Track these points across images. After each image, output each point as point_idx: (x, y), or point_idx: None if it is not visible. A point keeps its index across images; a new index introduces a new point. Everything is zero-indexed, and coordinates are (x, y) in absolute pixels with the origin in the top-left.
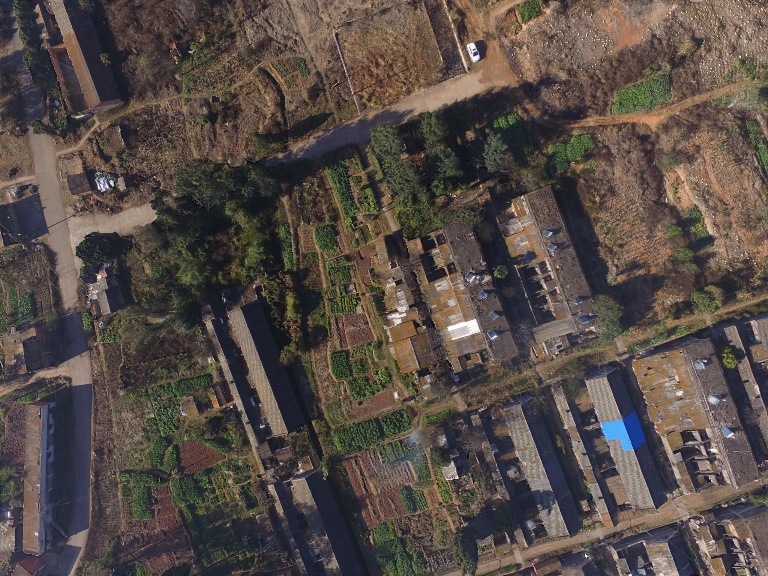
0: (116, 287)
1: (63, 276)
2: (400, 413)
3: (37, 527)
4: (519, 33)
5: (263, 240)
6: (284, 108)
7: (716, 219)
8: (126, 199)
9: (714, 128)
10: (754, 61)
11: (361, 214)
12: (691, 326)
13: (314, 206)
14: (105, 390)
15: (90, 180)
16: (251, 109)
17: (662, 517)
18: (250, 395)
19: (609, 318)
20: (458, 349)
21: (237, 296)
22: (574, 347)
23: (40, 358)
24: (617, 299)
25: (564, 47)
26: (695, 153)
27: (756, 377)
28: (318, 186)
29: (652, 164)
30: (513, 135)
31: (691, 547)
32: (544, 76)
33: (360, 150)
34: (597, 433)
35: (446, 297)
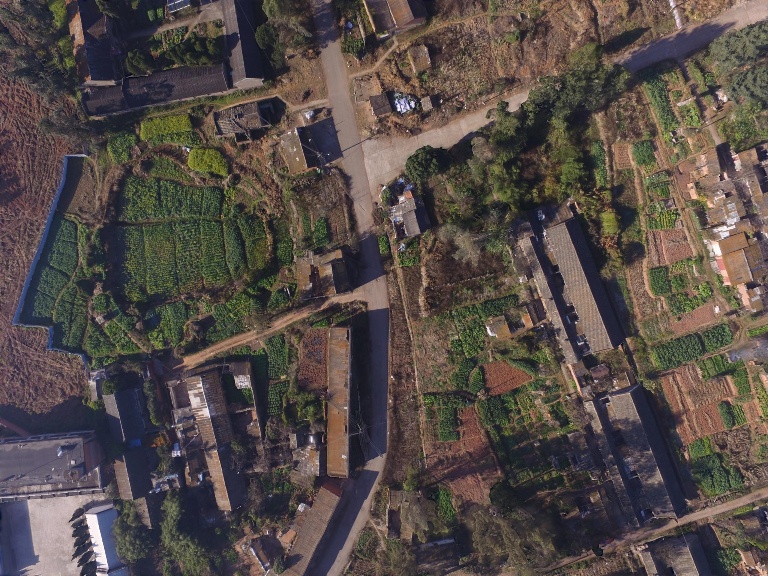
0: (423, 208)
1: (358, 200)
2: (722, 327)
3: (344, 450)
4: None
5: None
6: (597, 24)
7: None
8: (427, 120)
9: None
10: None
11: (682, 128)
12: None
13: (631, 122)
14: (402, 314)
15: (389, 101)
16: (561, 26)
17: None
18: (565, 313)
19: None
20: None
21: (552, 214)
22: None
23: (346, 280)
24: None
25: None
26: None
27: None
28: (636, 101)
29: None
30: None
31: None
32: None
33: (679, 64)
34: None
35: None
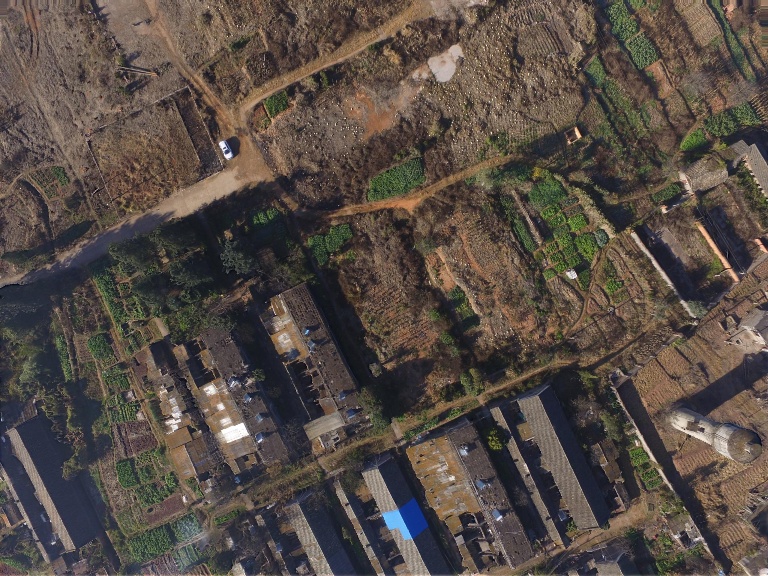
0: None
1: None
2: (189, 517)
3: None
4: (268, 128)
5: (39, 353)
6: (48, 218)
7: (479, 298)
8: None
9: (467, 208)
10: (506, 136)
11: (131, 321)
12: (464, 407)
13: (86, 316)
14: None
15: None
16: (16, 221)
17: None
18: (40, 511)
19: (372, 411)
20: (233, 452)
21: (17, 413)
22: (349, 439)
23: None
24: (376, 393)
25: (314, 138)
26: (451, 235)
27: (525, 455)
28: (87, 296)
29: (412, 248)
30: (274, 230)
31: None
32: (296, 169)
33: None
34: (384, 520)
35: (215, 401)
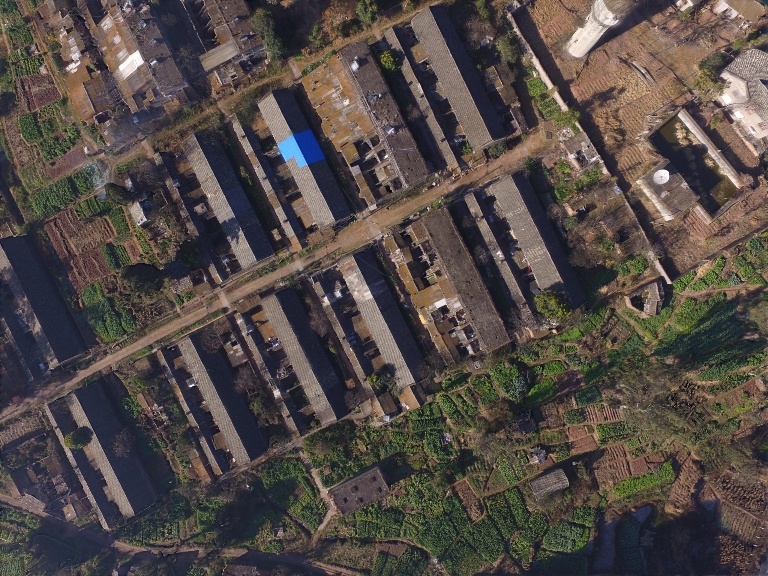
0: None
1: None
2: (91, 167)
3: None
4: None
5: None
6: None
7: None
8: None
9: None
10: None
11: None
12: None
13: None
14: None
15: None
16: None
17: (356, 239)
18: None
19: (264, 30)
20: (130, 87)
21: None
22: None
23: None
24: (268, 9)
25: None
26: None
27: (419, 77)
28: None
29: None
30: None
31: (385, 264)
32: None
33: None
34: None
35: (112, 35)
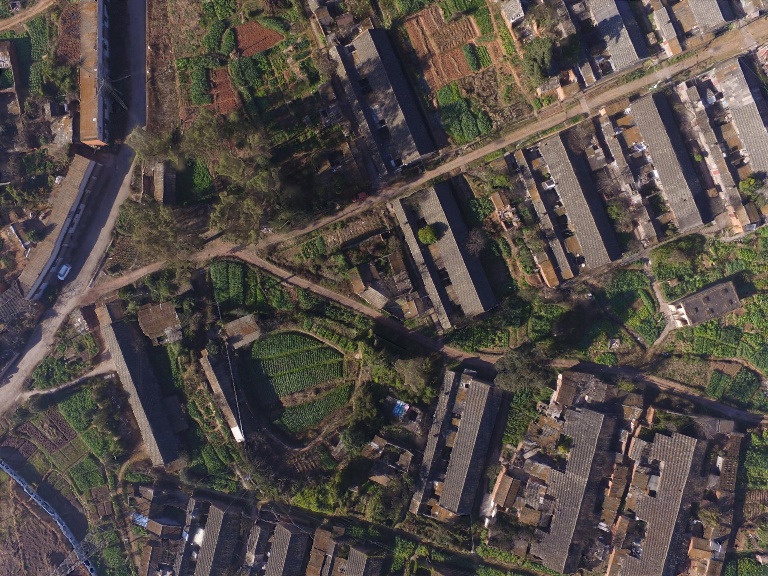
0: None
1: None
2: None
3: (95, 112)
4: None
5: None
6: None
7: None
8: None
9: None
10: None
11: None
12: None
13: None
14: None
15: None
16: None
17: (729, 49)
18: None
19: None
20: None
21: None
22: None
23: None
24: None
25: None
26: None
27: None
28: None
29: None
30: None
31: (760, 73)
32: None
33: None
34: None
35: None
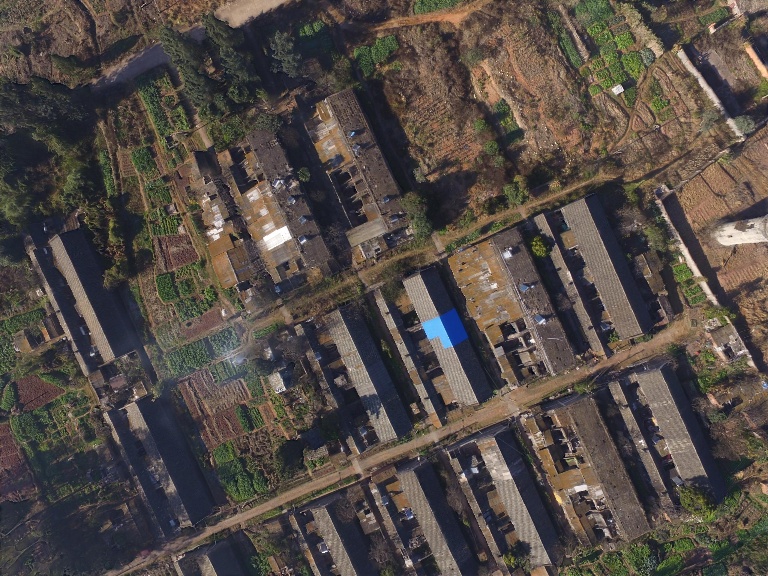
0: None
1: None
2: (228, 330)
3: None
4: None
5: (83, 168)
6: (95, 33)
7: (524, 111)
8: None
9: (514, 20)
10: None
11: (175, 133)
12: (507, 220)
13: (130, 129)
14: None
15: None
16: (63, 38)
17: (493, 415)
18: (79, 324)
19: (416, 214)
20: (274, 259)
21: (60, 225)
22: (391, 249)
23: None
24: (421, 193)
25: None
26: (497, 46)
27: (568, 264)
28: (132, 108)
29: (458, 61)
30: (320, 43)
31: (523, 442)
32: None
33: (171, 69)
34: (423, 335)
35: (258, 207)
